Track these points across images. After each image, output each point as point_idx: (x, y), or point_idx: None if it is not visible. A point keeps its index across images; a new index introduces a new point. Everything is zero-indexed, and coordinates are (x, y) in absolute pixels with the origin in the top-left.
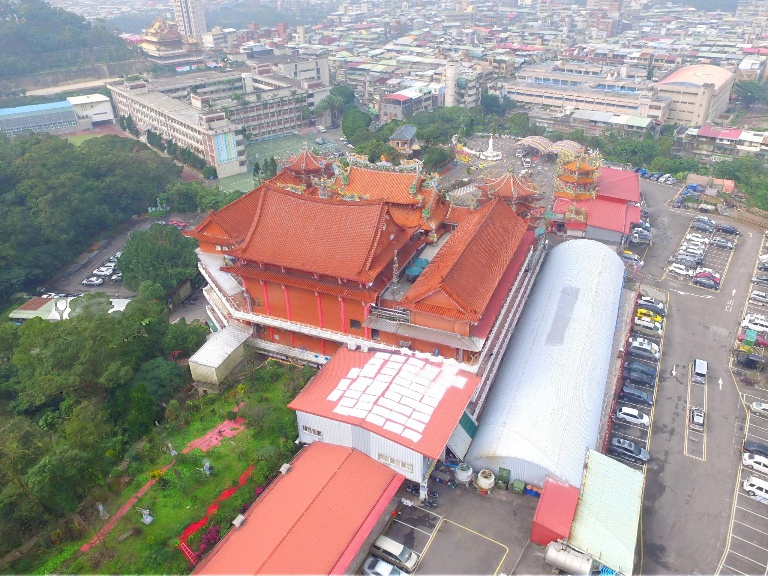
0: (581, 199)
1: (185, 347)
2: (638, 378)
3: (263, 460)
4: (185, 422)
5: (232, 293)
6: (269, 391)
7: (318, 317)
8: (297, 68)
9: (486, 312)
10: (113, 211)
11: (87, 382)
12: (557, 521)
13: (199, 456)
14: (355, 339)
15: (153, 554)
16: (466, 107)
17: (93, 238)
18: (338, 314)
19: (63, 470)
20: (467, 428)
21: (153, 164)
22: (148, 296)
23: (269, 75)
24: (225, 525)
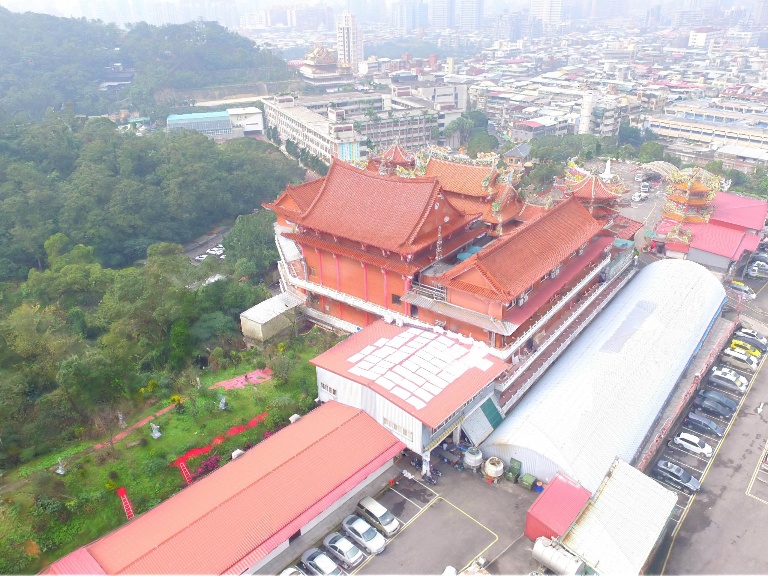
0: (691, 222)
1: (243, 305)
2: (711, 407)
3: (277, 407)
4: (222, 367)
5: (291, 259)
6: (305, 352)
7: (364, 290)
8: (436, 92)
9: (530, 302)
10: (236, 202)
11: (147, 318)
12: (555, 518)
13: (220, 393)
14: (393, 313)
15: (150, 463)
16: (601, 137)
17: (215, 223)
18: (381, 288)
19: (89, 371)
20: (490, 417)
21: (280, 164)
22: (241, 272)
23: (407, 97)
24: (226, 457)
